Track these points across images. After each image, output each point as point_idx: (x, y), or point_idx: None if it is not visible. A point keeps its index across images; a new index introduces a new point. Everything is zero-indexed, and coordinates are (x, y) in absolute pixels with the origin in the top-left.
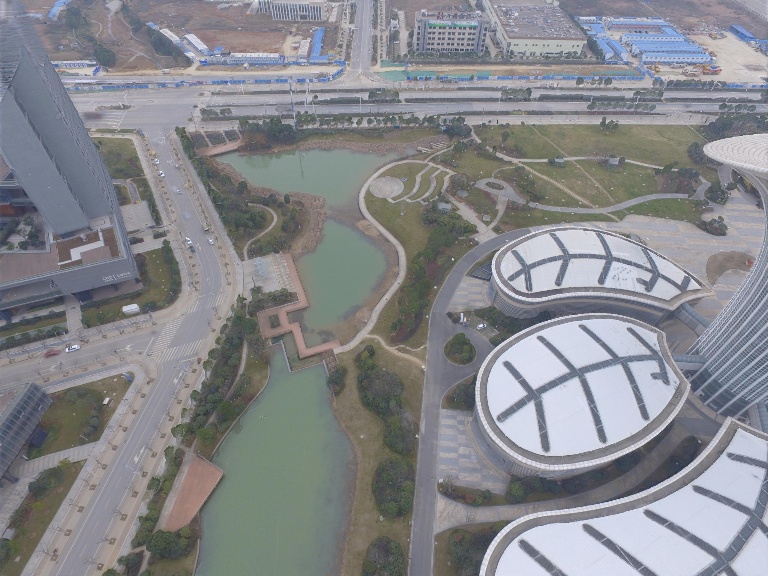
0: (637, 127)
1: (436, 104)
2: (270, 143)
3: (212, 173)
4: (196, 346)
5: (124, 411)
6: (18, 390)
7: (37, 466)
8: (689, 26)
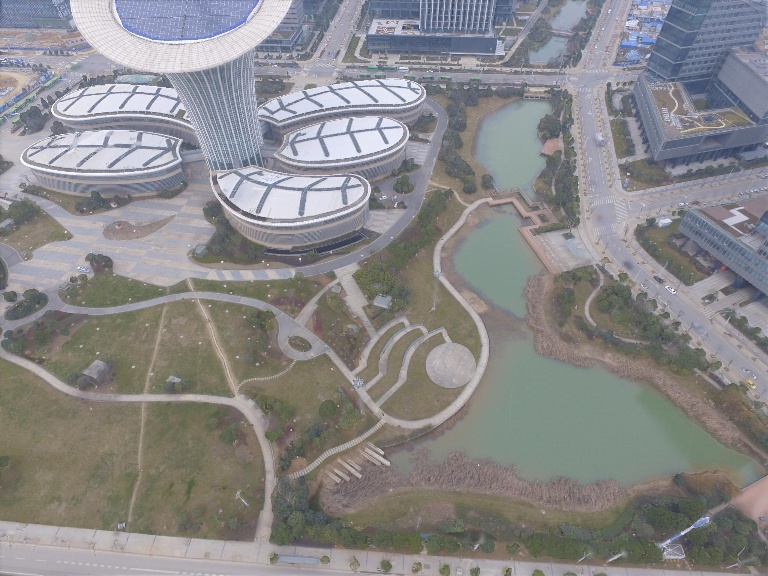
0: None
1: None
2: None
3: (725, 391)
4: (594, 202)
5: (615, 175)
6: (669, 138)
7: (641, 156)
8: None
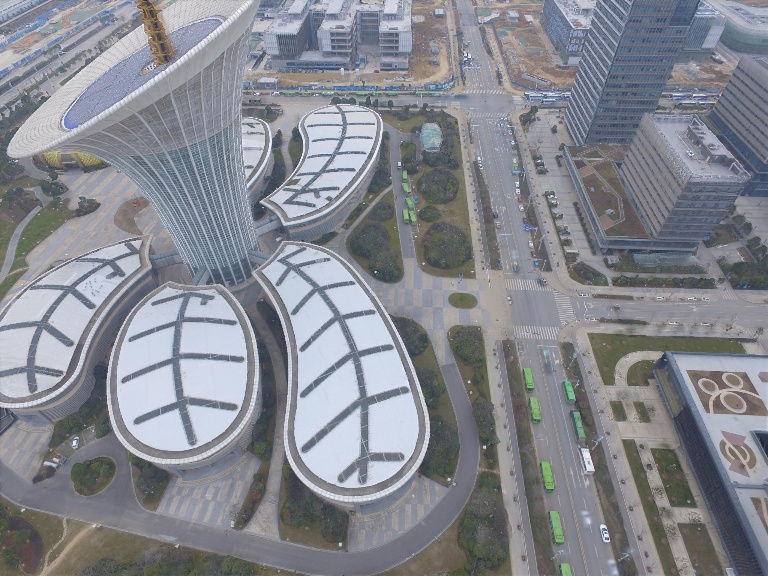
0: None
1: None
2: None
3: None
4: None
5: None
6: None
7: None
8: None
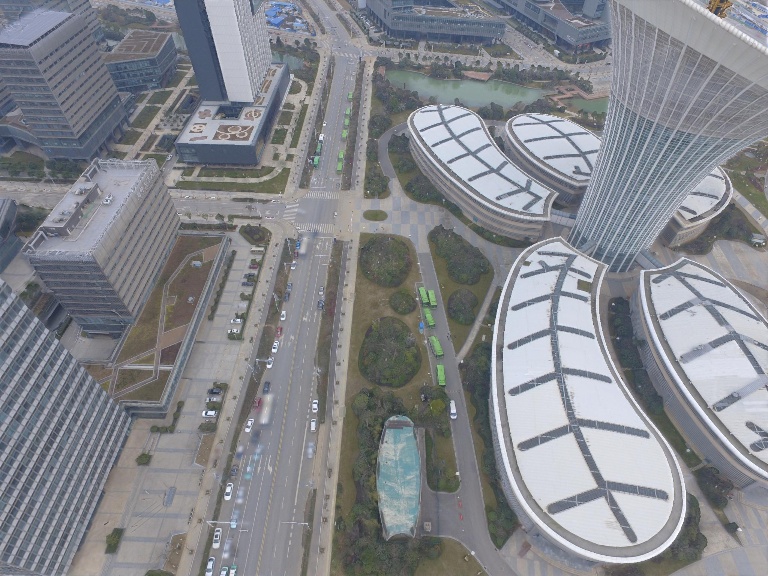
0: None
1: None
2: None
3: None
4: None
5: None
6: None
7: None
8: None
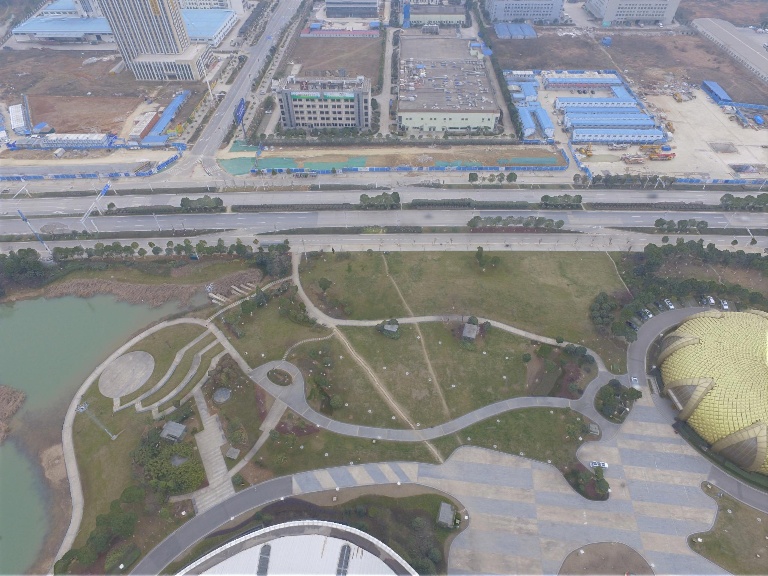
0: (532, 256)
1: (270, 214)
2: (10, 286)
3: None
4: None
5: None
6: None
7: None
8: (650, 82)
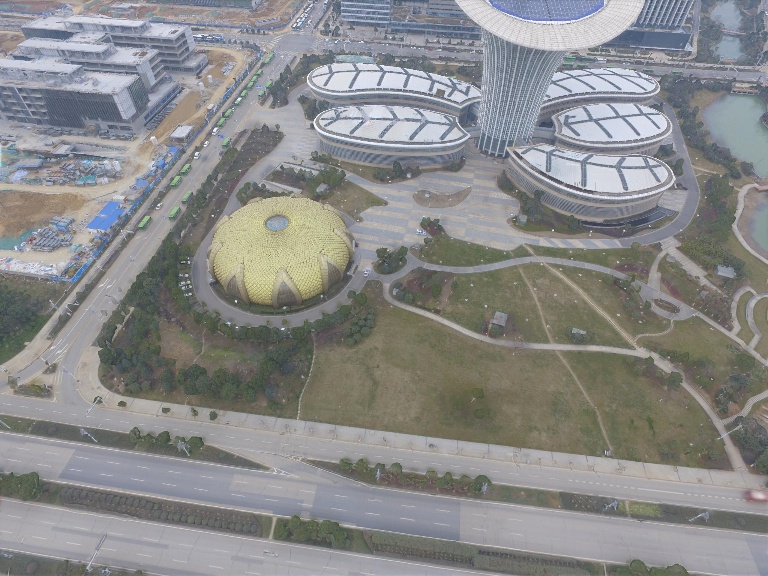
0: (403, 420)
1: None
2: None
3: None
4: None
5: None
6: None
7: None
8: None
